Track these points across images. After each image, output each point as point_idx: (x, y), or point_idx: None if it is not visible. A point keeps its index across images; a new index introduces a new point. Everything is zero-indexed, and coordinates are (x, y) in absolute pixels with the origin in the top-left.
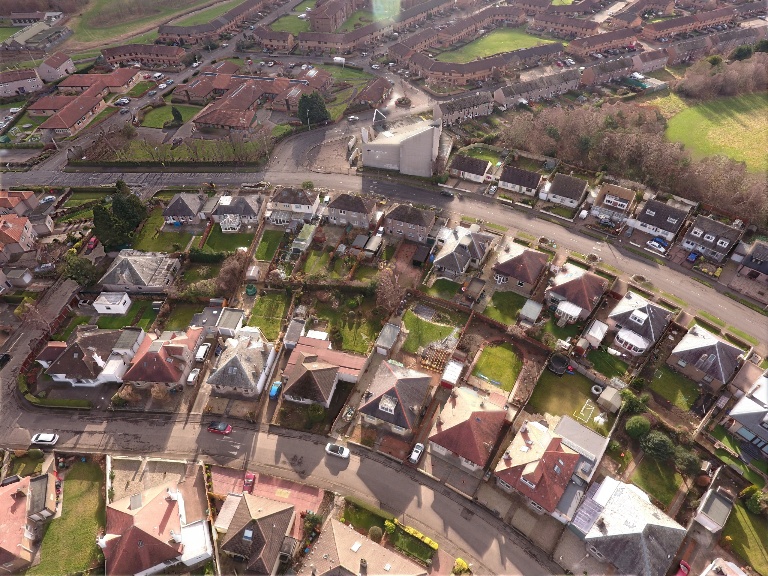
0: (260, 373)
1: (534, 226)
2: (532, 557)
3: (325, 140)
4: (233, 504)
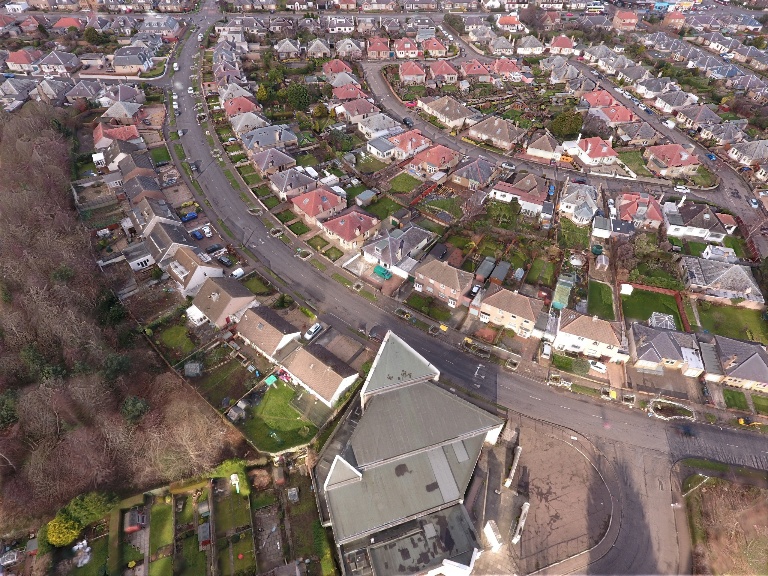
0: (564, 187)
1: (301, 274)
2: (422, 134)
3: (586, 568)
4: (558, 151)
